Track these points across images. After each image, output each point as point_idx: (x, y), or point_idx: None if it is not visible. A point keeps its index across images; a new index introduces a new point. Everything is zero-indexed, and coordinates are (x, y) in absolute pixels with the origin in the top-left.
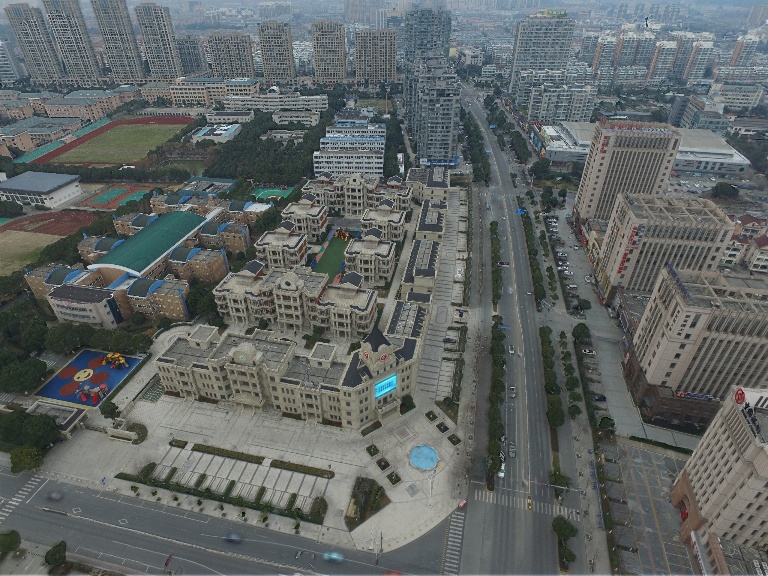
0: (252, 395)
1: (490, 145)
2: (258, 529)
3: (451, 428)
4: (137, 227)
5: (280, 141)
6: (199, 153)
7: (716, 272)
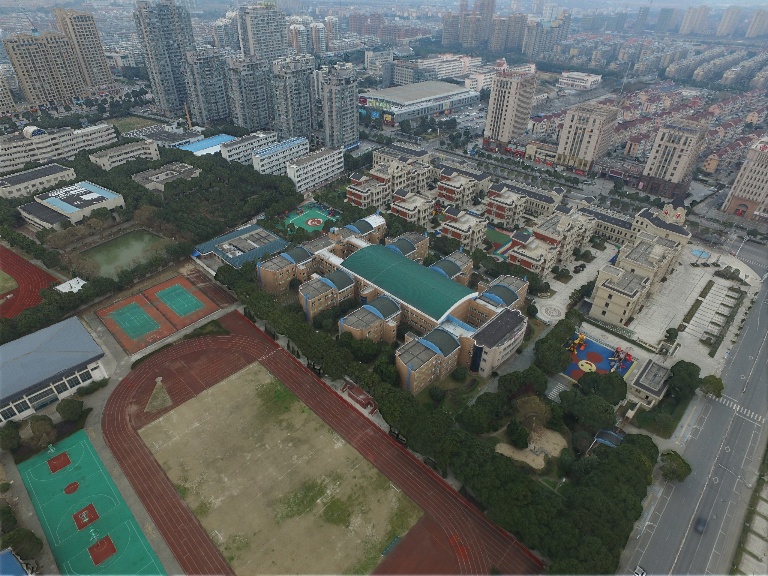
0: None
1: None
2: (751, 311)
3: None
4: None
5: (198, 177)
6: None
7: None
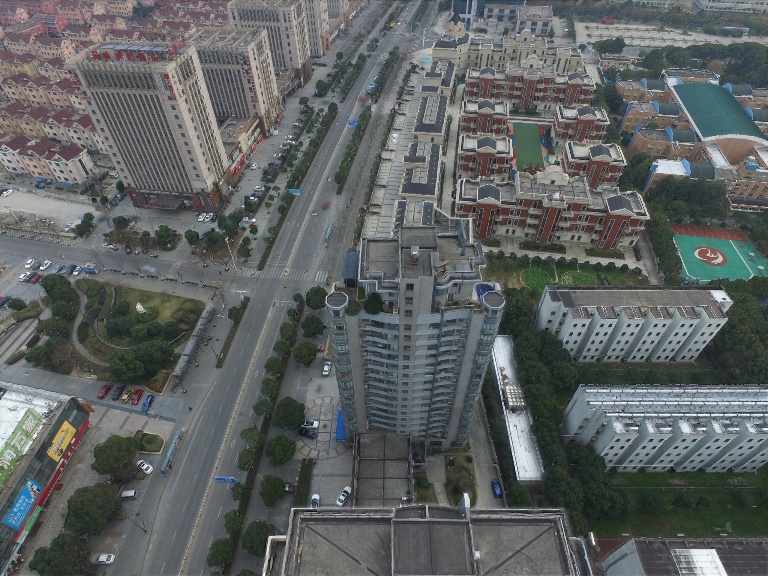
0: None
1: None
2: None
3: None
4: None
5: None
6: None
7: (264, 6)
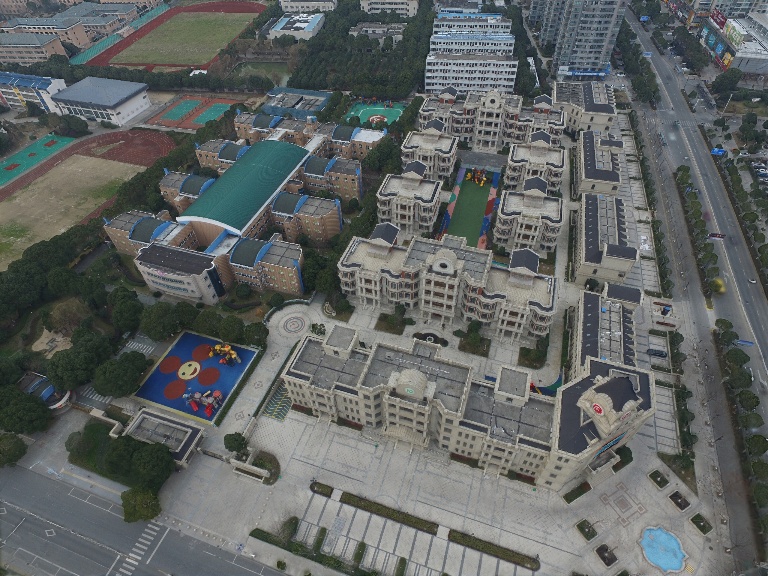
0: (413, 431)
1: (643, 46)
2: None
3: (691, 502)
4: (225, 160)
5: (377, 38)
6: (278, 53)
7: None
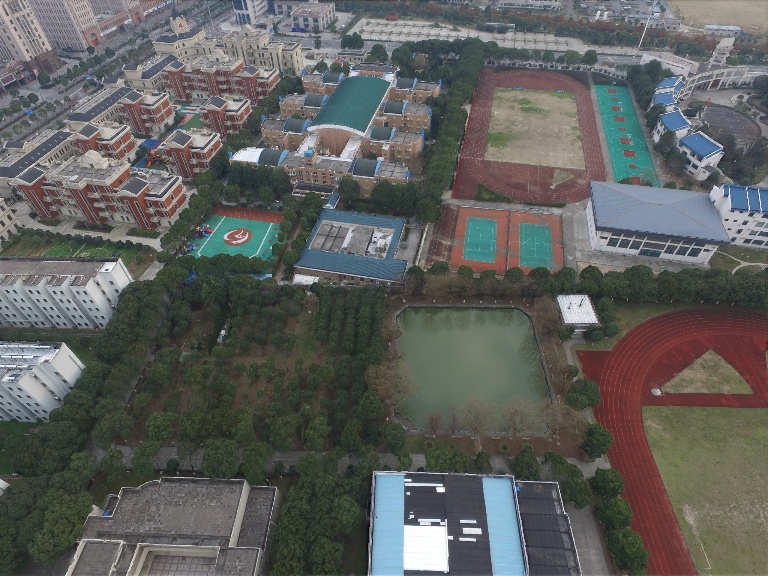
0: None
1: None
2: None
3: None
4: None
5: (182, 430)
6: None
7: None
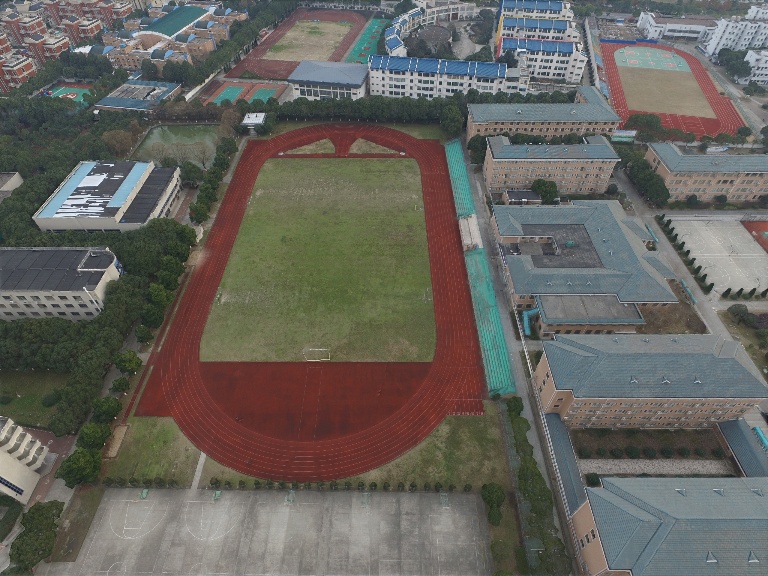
0: None
1: None
2: None
3: None
4: None
5: None
6: None
7: None
